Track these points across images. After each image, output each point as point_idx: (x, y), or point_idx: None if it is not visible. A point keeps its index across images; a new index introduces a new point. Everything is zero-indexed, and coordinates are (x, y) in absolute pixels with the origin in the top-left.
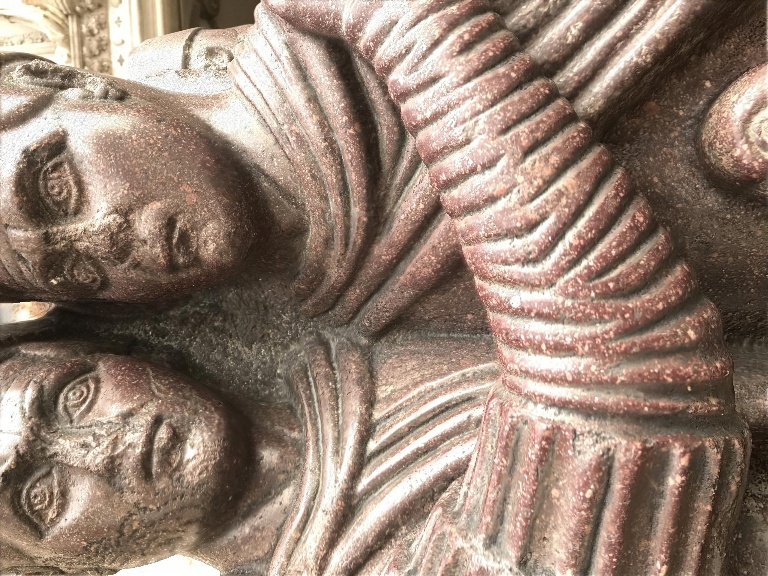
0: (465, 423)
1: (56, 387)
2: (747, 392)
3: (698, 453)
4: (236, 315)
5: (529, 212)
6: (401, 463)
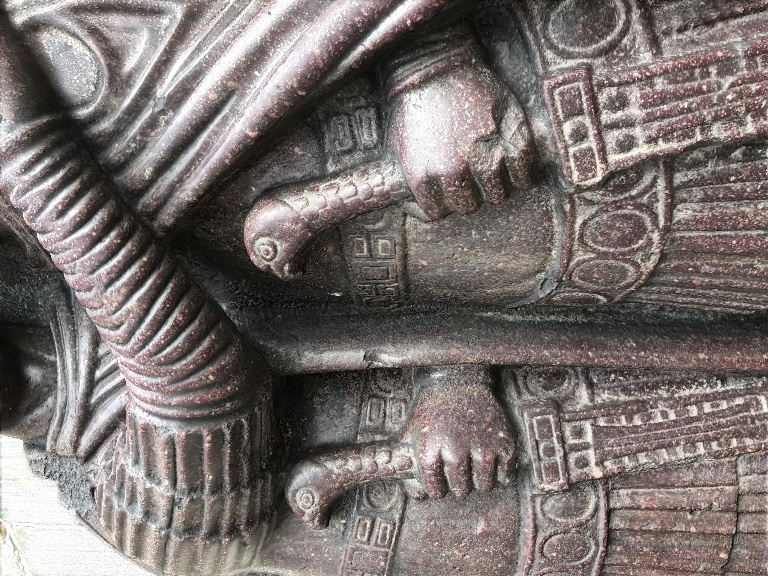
0: None
1: None
2: (297, 356)
3: (218, 431)
4: None
5: (113, 320)
6: (115, 387)
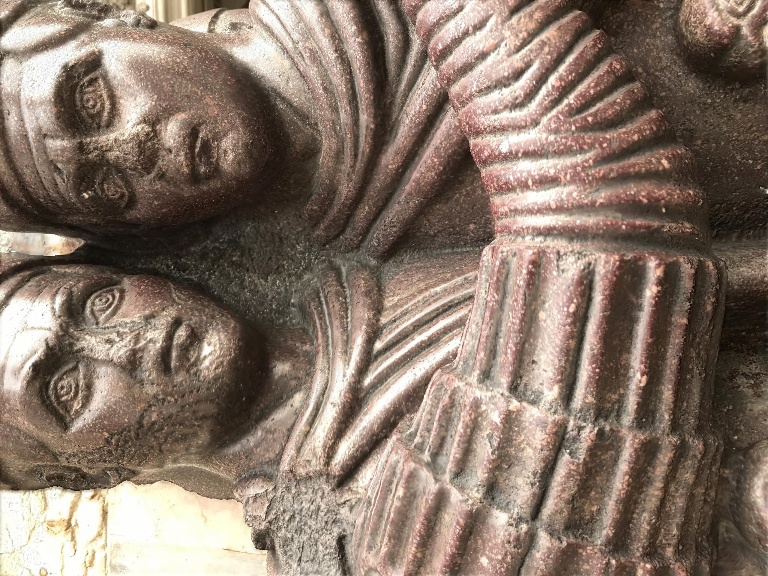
0: (466, 316)
1: (84, 293)
2: (732, 263)
3: (673, 268)
4: (253, 249)
5: (515, 61)
6: (406, 356)
